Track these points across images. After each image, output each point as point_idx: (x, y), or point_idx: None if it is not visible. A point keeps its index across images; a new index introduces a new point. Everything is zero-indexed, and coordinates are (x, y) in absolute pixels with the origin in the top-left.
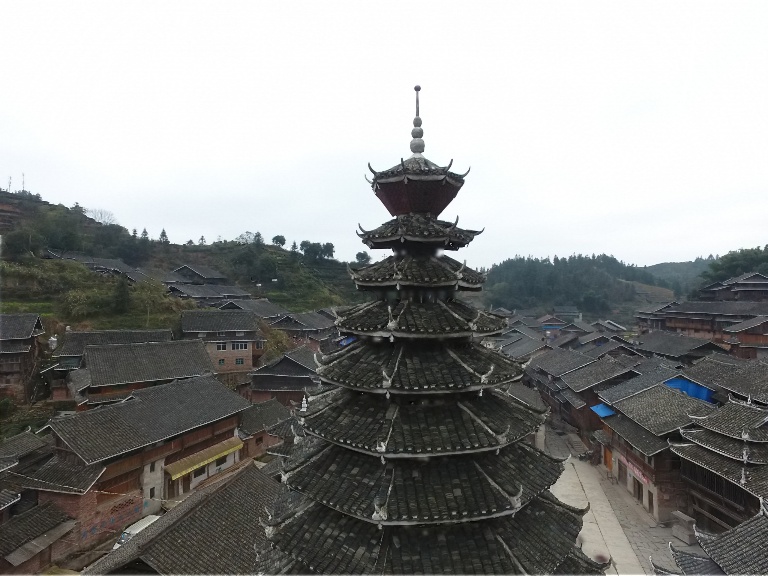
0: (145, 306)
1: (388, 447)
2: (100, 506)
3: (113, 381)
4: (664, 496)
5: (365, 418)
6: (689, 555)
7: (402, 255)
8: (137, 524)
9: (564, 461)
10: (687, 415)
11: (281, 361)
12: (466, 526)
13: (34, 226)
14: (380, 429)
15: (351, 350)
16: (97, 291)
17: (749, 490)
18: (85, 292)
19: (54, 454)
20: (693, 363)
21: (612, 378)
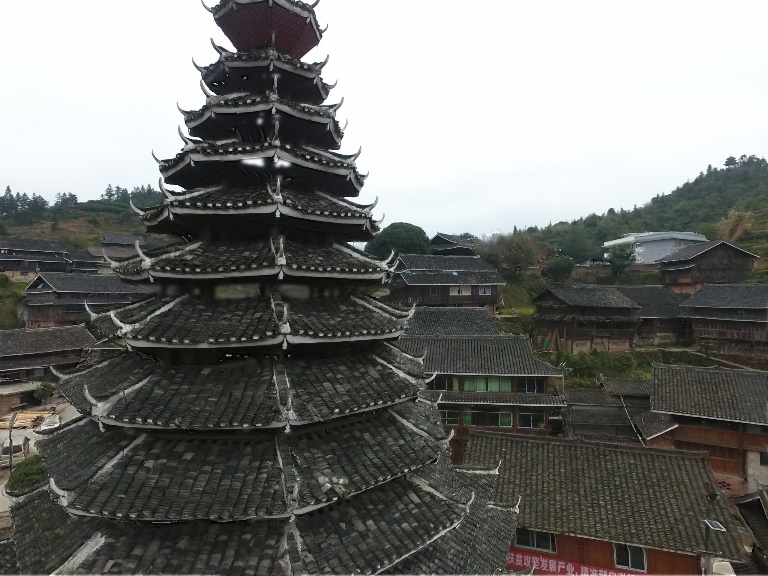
0: None
1: None
2: None
3: None
4: None
5: None
6: None
7: None
8: None
9: (119, 322)
10: None
11: None
12: None
13: None
14: None
15: None
16: None
17: None
18: None
19: None
20: None
21: None
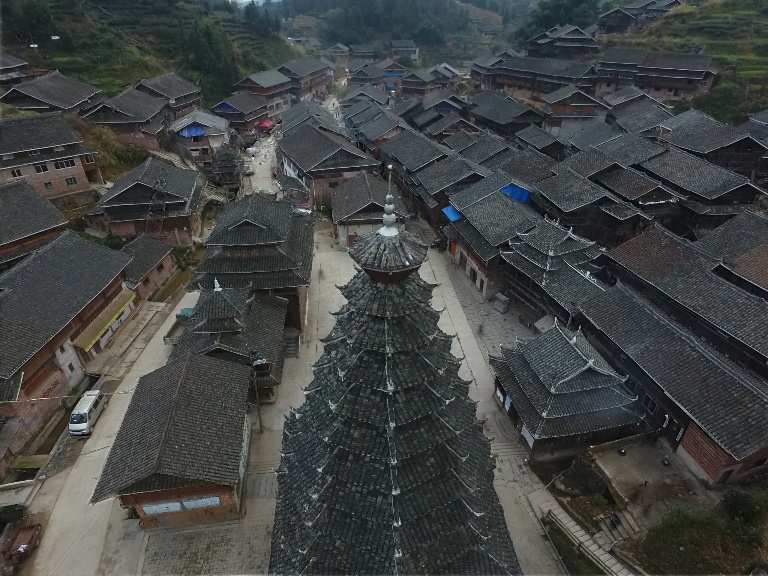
0: None
1: (398, 459)
2: None
3: None
4: (491, 283)
5: (371, 431)
6: (510, 351)
7: None
8: (81, 404)
9: None
10: (516, 232)
11: (133, 187)
12: None
13: None
14: (386, 443)
15: (350, 385)
16: None
17: (546, 290)
18: None
19: None
20: (516, 135)
21: (460, 180)
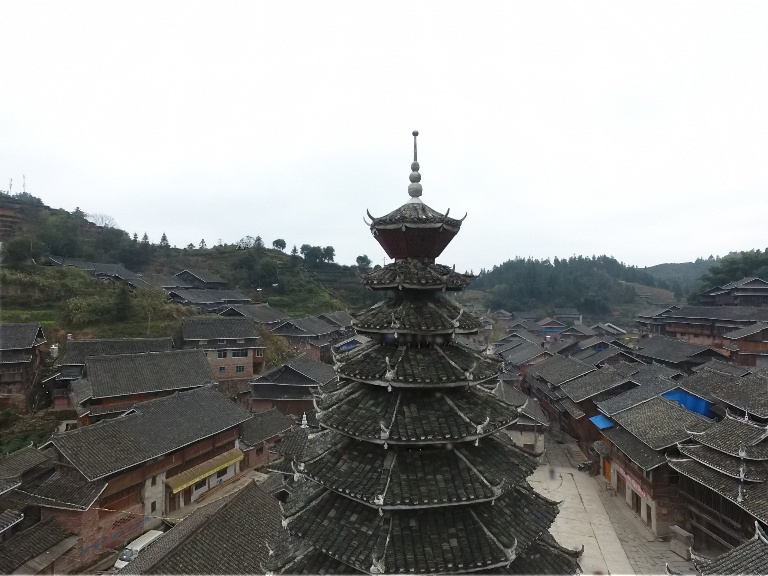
0: (146, 313)
1: (386, 499)
2: (102, 521)
3: (114, 392)
4: (662, 510)
5: (364, 465)
6: None
7: (400, 299)
8: (139, 540)
9: (559, 504)
10: (685, 430)
11: None
12: (462, 574)
13: (35, 233)
14: (378, 479)
15: (350, 394)
16: (98, 298)
17: (746, 509)
18: (86, 299)
19: (56, 469)
20: (692, 370)
21: (611, 388)
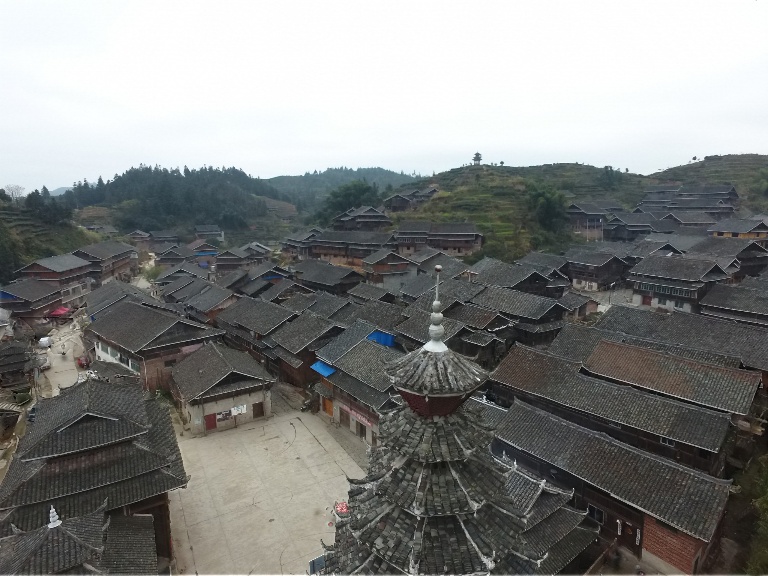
0: None
1: None
2: None
3: None
4: None
5: None
6: None
7: None
8: None
9: None
10: None
11: None
12: None
13: None
14: None
15: None
16: None
17: None
18: None
19: None
20: (348, 292)
21: (322, 335)
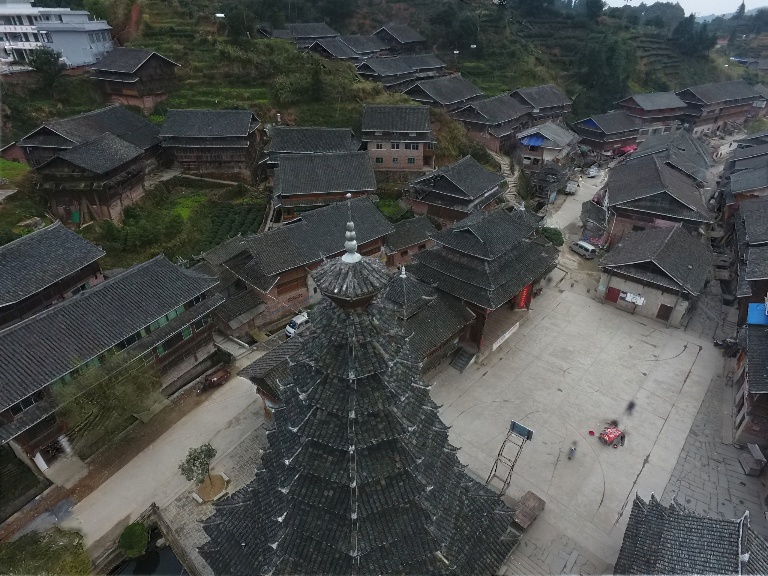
0: (337, 93)
1: (290, 463)
2: (280, 297)
3: (296, 191)
4: (753, 426)
5: None
6: (661, 509)
7: None
8: (300, 316)
9: (428, 487)
10: None
11: None
12: None
13: (246, 4)
14: None
15: None
16: (298, 76)
17: None
18: (289, 77)
19: (253, 257)
20: None
21: None
